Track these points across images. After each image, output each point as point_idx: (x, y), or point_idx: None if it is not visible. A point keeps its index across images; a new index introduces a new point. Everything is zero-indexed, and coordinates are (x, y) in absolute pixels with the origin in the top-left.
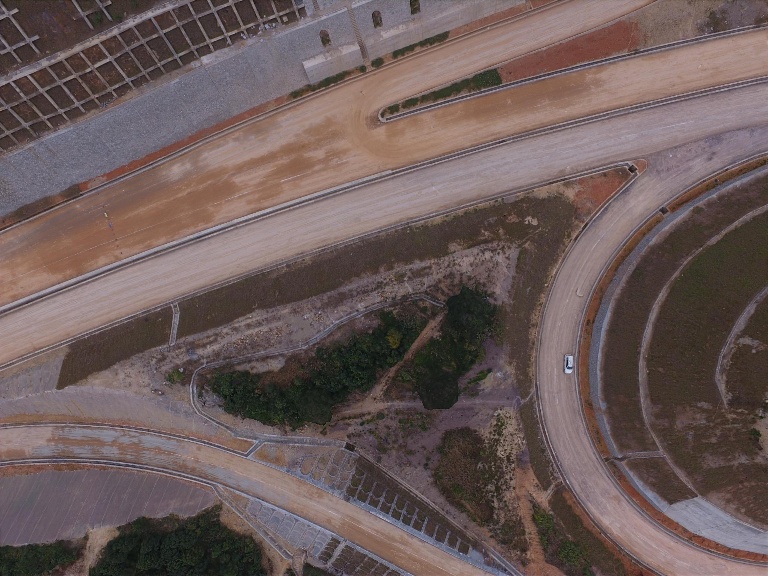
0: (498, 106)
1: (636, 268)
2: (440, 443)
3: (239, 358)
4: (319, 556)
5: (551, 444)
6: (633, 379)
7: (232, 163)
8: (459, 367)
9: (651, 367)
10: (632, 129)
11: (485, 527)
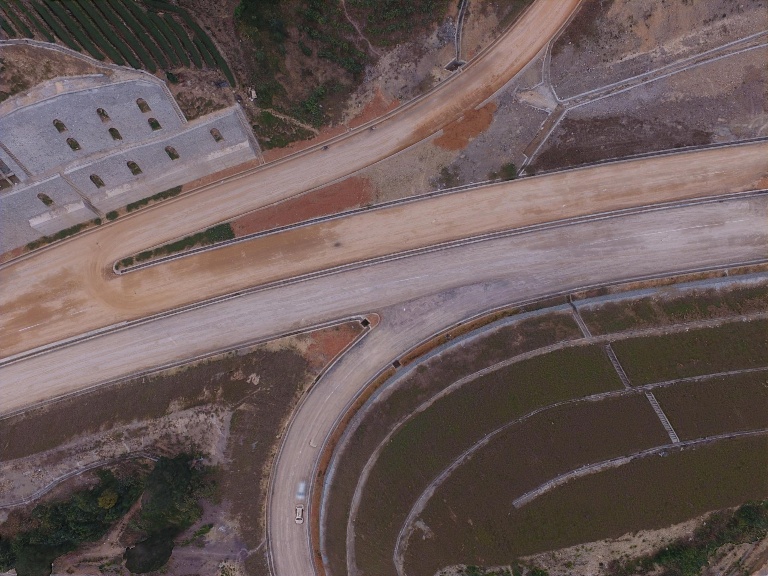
0: (232, 259)
1: (360, 425)
2: None
3: None
4: None
5: None
6: (342, 541)
7: None
8: (183, 521)
9: (357, 532)
10: (366, 283)
11: None
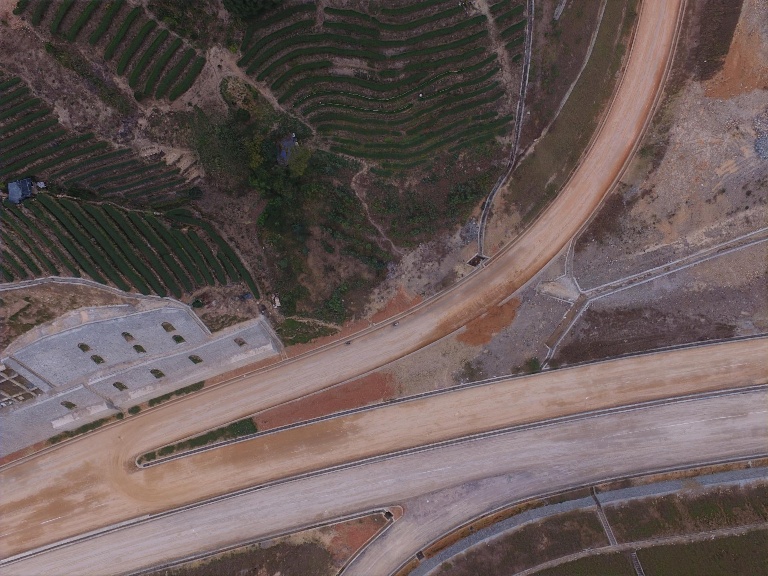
0: (255, 452)
1: None
2: None
3: None
4: None
5: None
6: None
7: None
8: None
9: None
10: (389, 475)
11: None
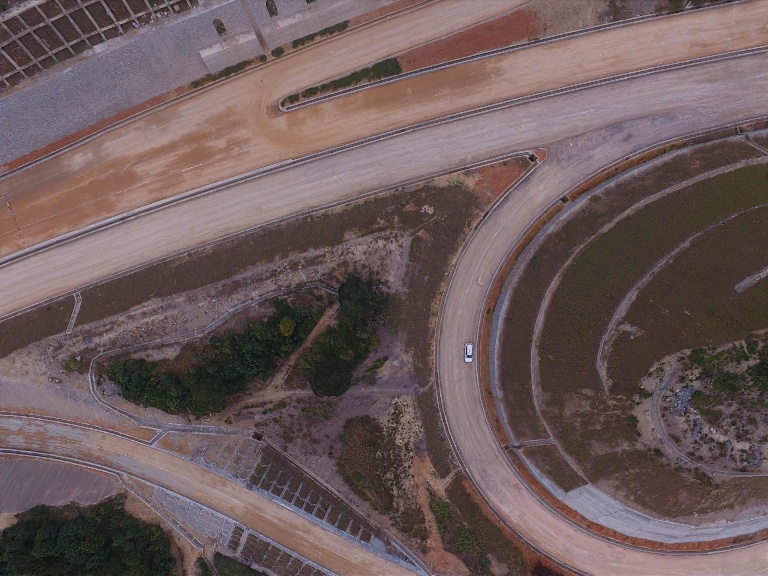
0: (398, 95)
1: (533, 256)
2: (342, 432)
3: (136, 346)
4: (228, 545)
5: (451, 432)
6: (525, 367)
7: (133, 152)
8: (356, 355)
9: (542, 355)
10: (533, 118)
11: (386, 515)
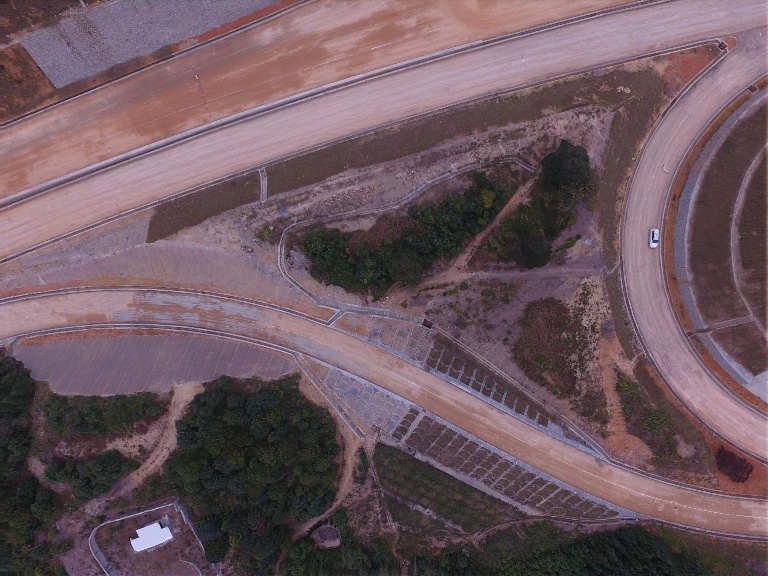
0: None
1: (726, 141)
2: (522, 315)
3: (330, 217)
4: (393, 433)
5: (634, 317)
6: (724, 245)
7: (323, 29)
8: (547, 234)
9: (743, 232)
10: (723, 7)
11: (566, 399)
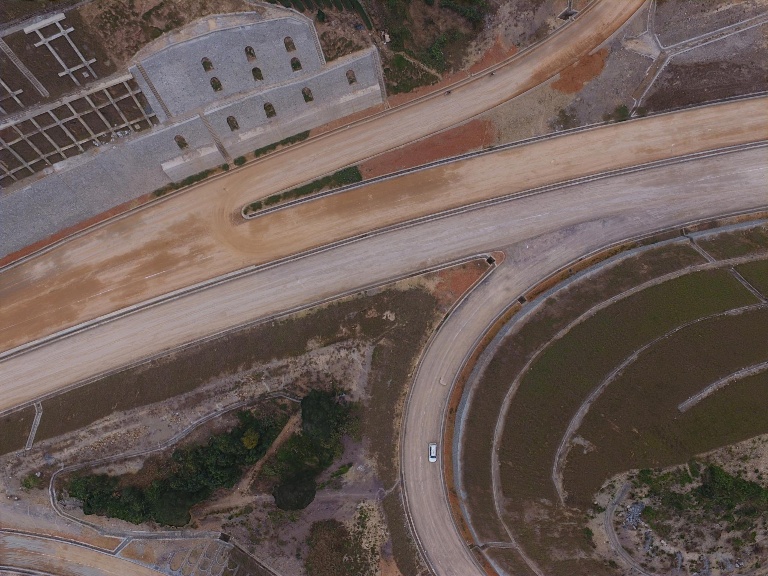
0: (359, 201)
1: (493, 359)
2: (309, 534)
3: (97, 460)
4: None
5: (417, 533)
6: (487, 472)
7: (95, 261)
8: (321, 462)
9: (502, 460)
10: (490, 222)
11: None
